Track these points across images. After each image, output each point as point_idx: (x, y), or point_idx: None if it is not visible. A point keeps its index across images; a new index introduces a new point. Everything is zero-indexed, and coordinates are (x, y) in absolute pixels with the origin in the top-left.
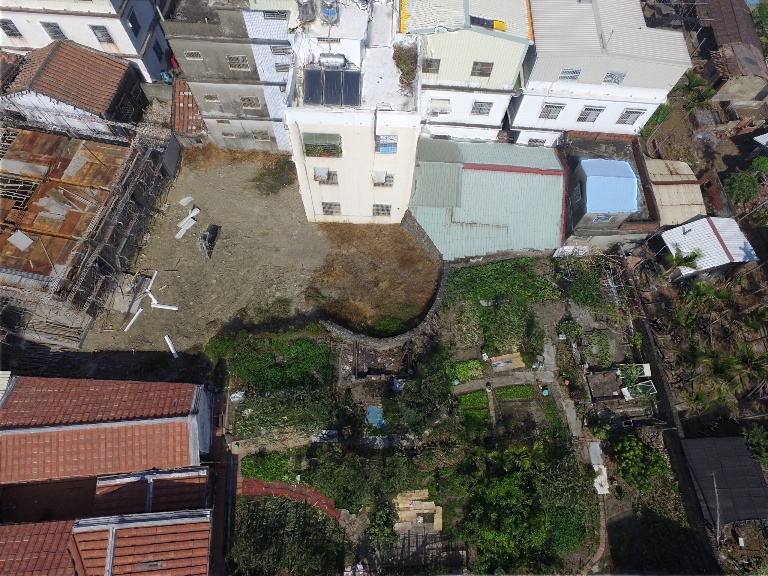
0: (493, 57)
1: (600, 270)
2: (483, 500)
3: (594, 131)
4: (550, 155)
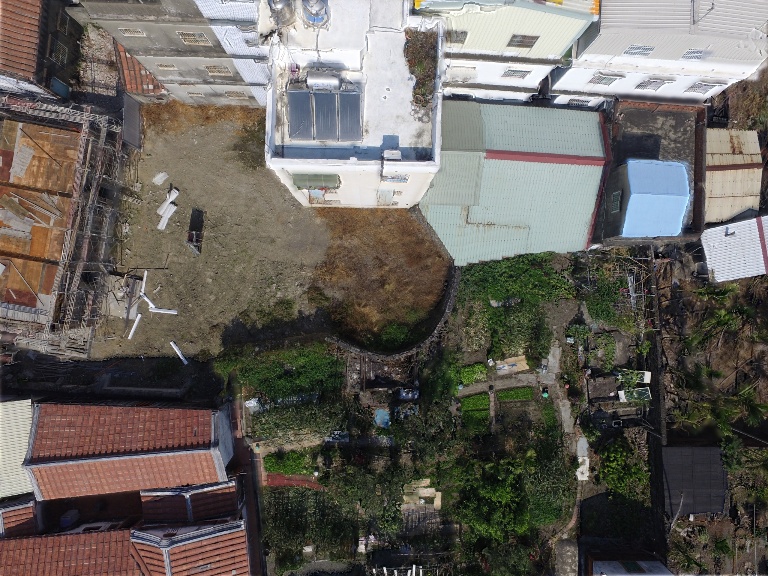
0: (540, 31)
1: (623, 277)
2: (477, 491)
3: (654, 102)
4: (593, 128)
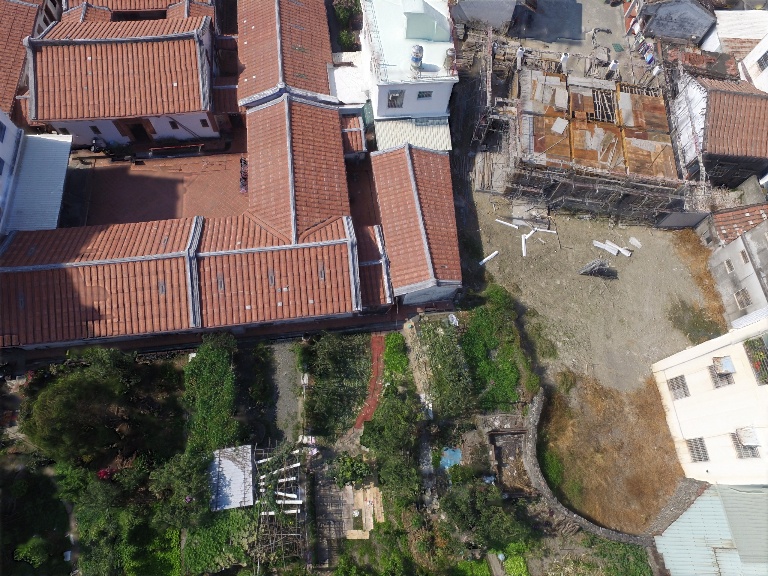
0: None
1: None
2: None
3: None
4: None
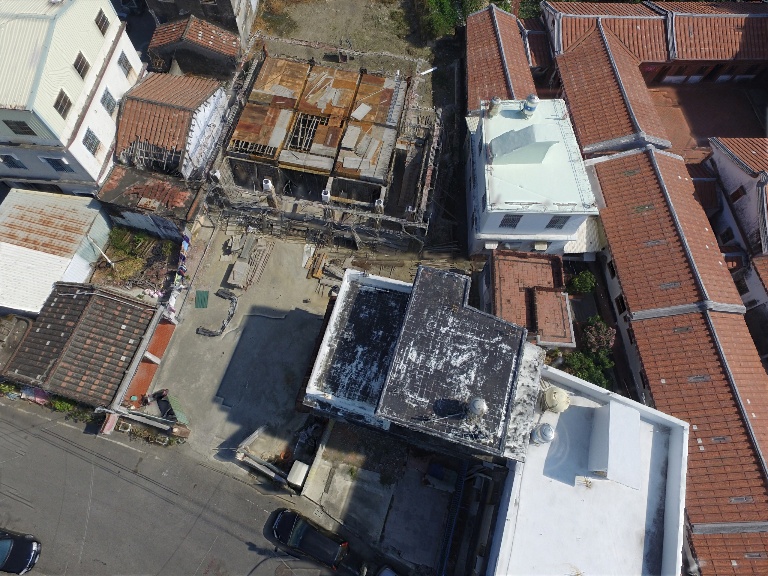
0: None
1: None
2: None
3: None
4: None
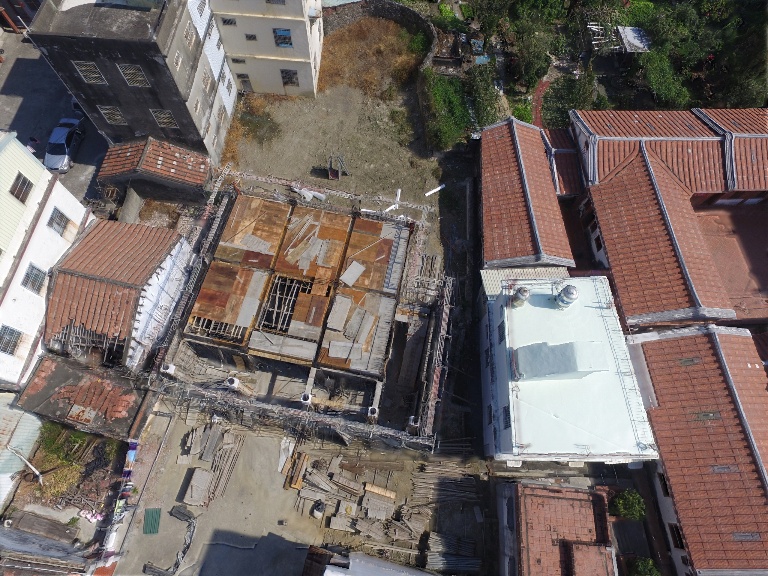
0: None
1: None
2: (531, 7)
3: None
4: None
